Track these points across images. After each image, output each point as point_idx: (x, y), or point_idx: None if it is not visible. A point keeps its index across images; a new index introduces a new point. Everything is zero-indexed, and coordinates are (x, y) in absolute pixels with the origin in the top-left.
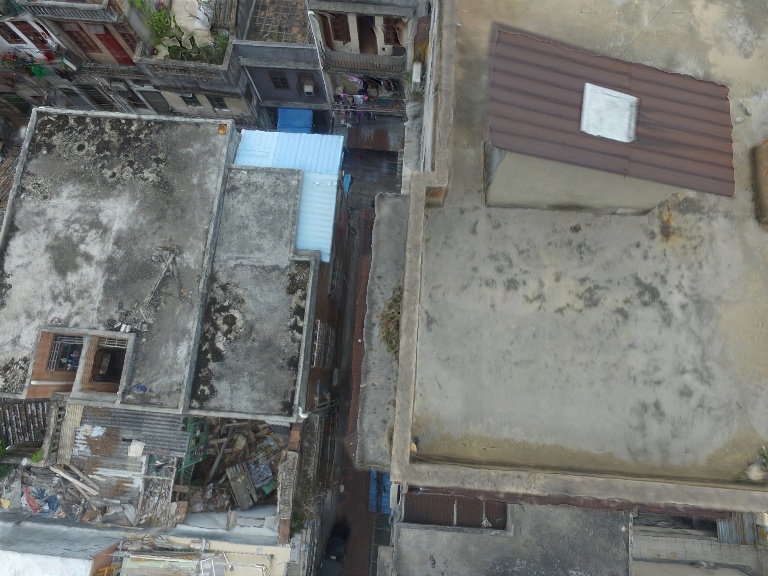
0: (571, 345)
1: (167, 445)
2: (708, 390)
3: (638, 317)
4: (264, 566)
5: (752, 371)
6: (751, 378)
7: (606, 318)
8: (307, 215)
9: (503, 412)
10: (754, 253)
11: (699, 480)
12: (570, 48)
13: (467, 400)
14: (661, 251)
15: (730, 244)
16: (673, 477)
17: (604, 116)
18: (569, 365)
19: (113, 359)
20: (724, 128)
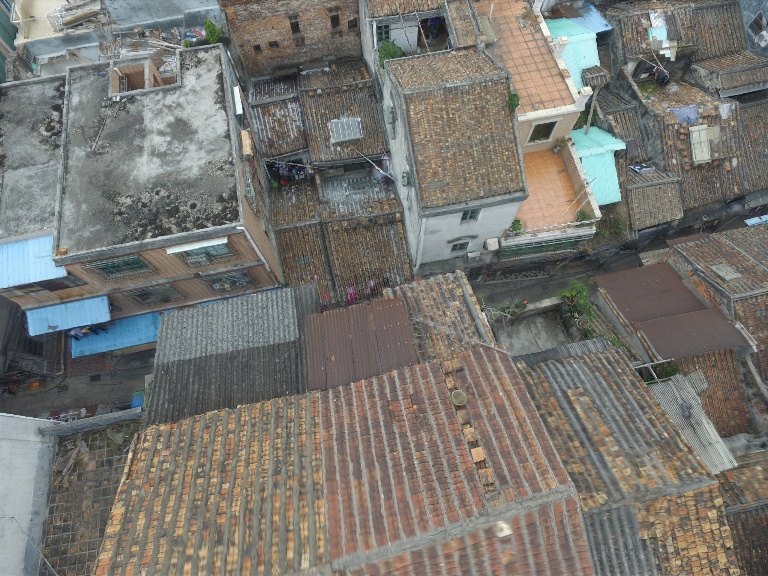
0: None
1: None
2: None
3: None
4: None
5: None
6: None
7: None
8: None
9: None
10: None
11: None
12: None
13: None
14: None
15: None
16: None
17: None
18: None
19: None
20: None
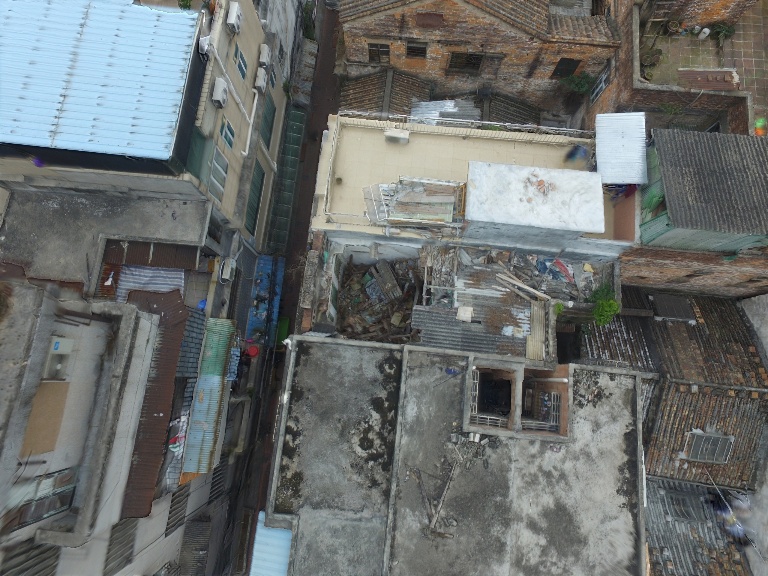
0: None
1: (434, 316)
2: None
3: None
4: None
5: None
6: None
7: None
8: (280, 575)
9: None
10: None
11: None
12: None
13: None
14: None
15: None
16: None
17: None
18: None
19: (523, 404)
20: None
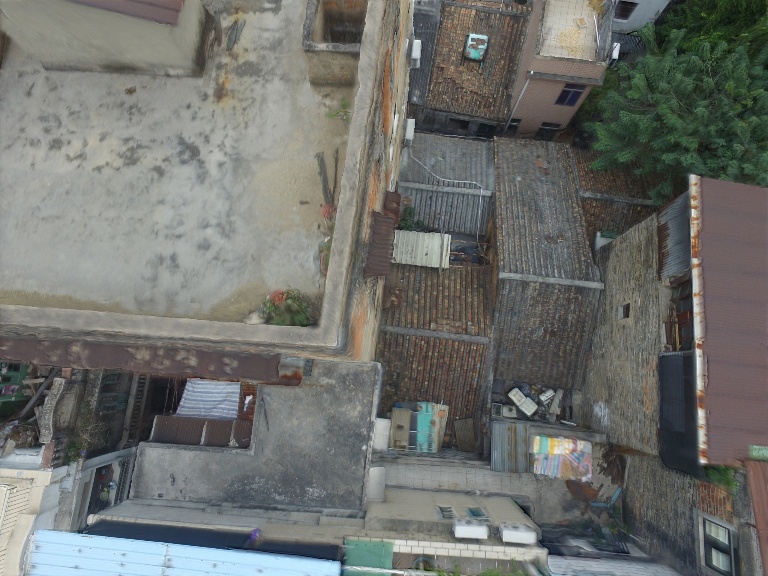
0: (100, 201)
1: None
2: (226, 243)
3: (173, 175)
4: (9, 485)
5: (274, 225)
6: (271, 232)
7: (141, 176)
8: None
9: (20, 265)
10: (301, 114)
11: None
12: None
13: None
14: (210, 112)
15: (279, 105)
16: None
17: None
18: (94, 220)
19: None
20: None
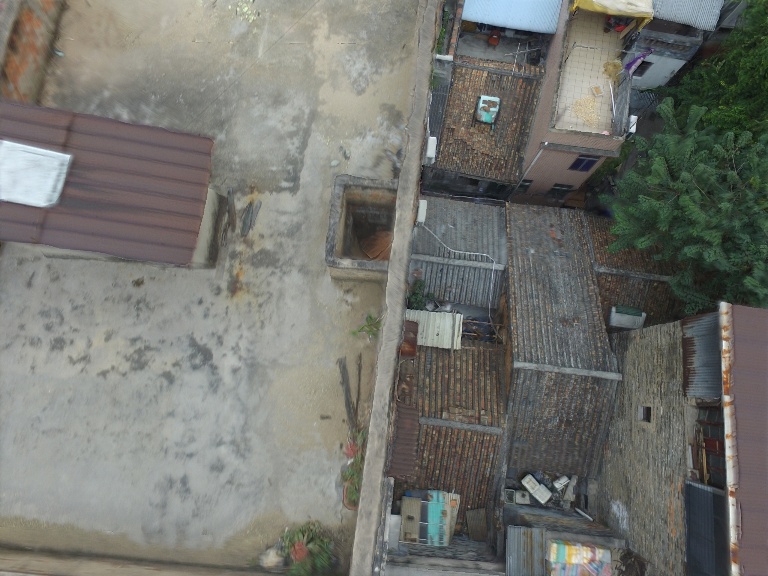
0: (105, 413)
1: None
2: (241, 464)
3: (184, 382)
4: None
5: (292, 443)
6: (289, 451)
7: (150, 383)
8: None
9: (18, 487)
10: (321, 312)
11: (192, 569)
12: (173, 81)
13: None
14: (223, 308)
15: (298, 301)
16: (173, 563)
17: (14, 177)
18: (99, 435)
19: None
20: (193, 187)
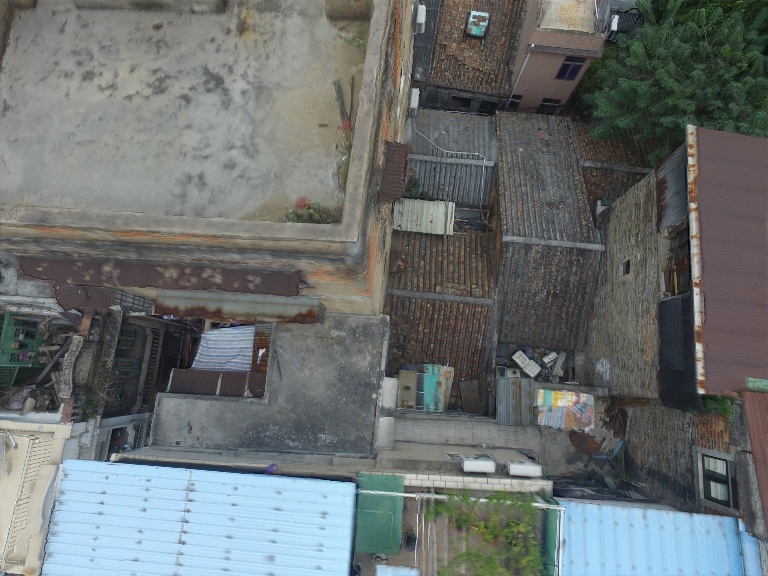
0: (132, 126)
1: None
2: (250, 163)
3: (199, 101)
4: (32, 436)
5: (294, 146)
6: (292, 152)
7: (170, 103)
8: None
9: (58, 184)
10: (318, 45)
11: None
12: None
13: (26, 174)
14: (233, 44)
15: (298, 37)
16: None
17: None
18: (127, 143)
19: None
20: None
